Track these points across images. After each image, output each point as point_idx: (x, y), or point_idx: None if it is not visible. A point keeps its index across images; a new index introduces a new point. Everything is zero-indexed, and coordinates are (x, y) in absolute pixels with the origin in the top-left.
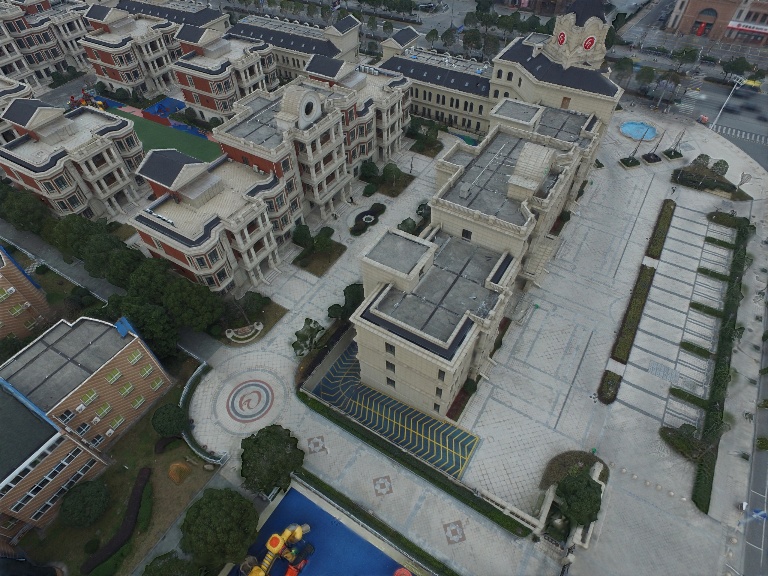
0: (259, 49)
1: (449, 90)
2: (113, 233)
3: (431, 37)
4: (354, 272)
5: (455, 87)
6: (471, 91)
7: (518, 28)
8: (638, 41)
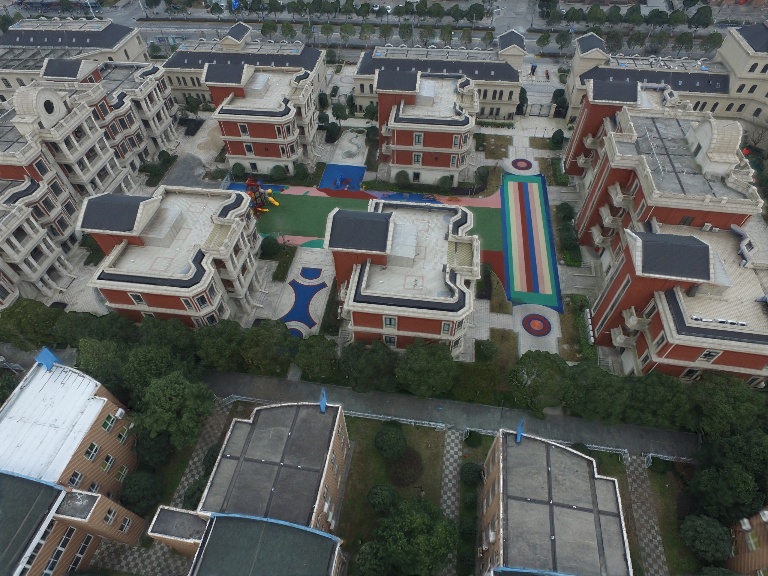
0: (465, 85)
1: (681, 93)
2: (495, 356)
3: (544, 42)
4: None
5: (685, 89)
6: (705, 90)
7: (611, 20)
8: None
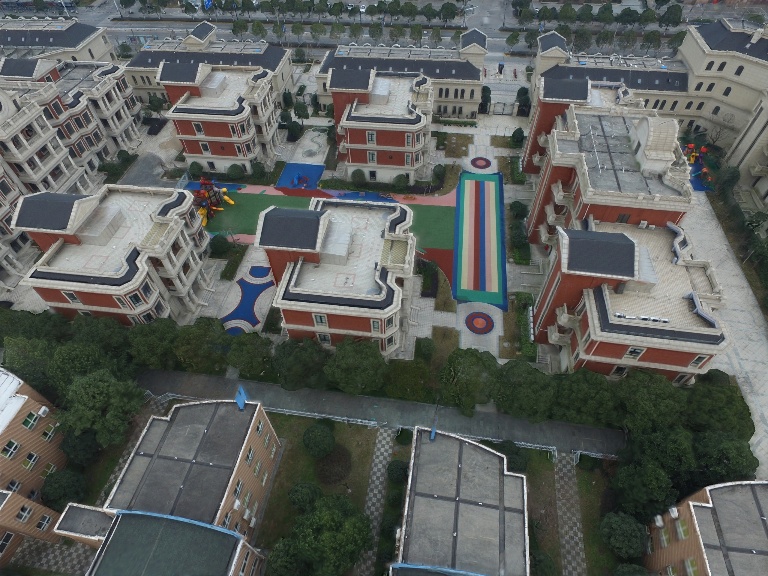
0: (422, 83)
1: (640, 91)
2: (434, 354)
3: (513, 40)
4: (738, 309)
5: (644, 87)
6: (664, 88)
7: (582, 19)
8: (683, 15)
